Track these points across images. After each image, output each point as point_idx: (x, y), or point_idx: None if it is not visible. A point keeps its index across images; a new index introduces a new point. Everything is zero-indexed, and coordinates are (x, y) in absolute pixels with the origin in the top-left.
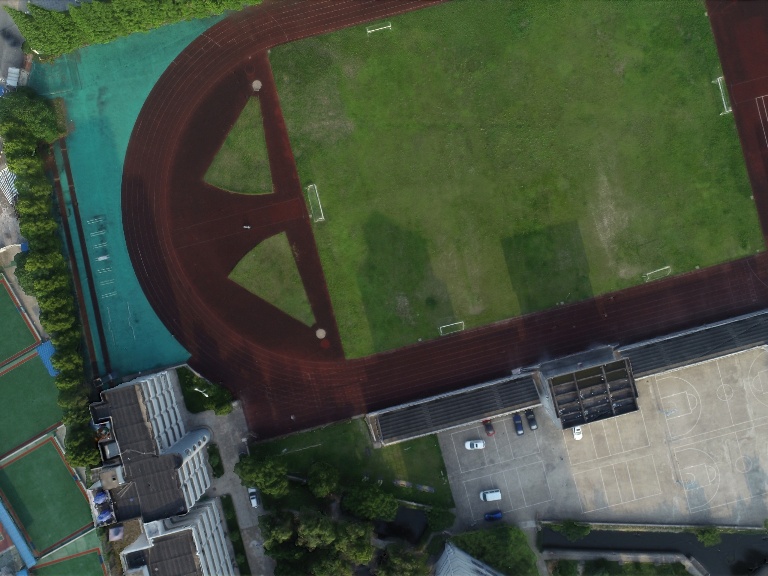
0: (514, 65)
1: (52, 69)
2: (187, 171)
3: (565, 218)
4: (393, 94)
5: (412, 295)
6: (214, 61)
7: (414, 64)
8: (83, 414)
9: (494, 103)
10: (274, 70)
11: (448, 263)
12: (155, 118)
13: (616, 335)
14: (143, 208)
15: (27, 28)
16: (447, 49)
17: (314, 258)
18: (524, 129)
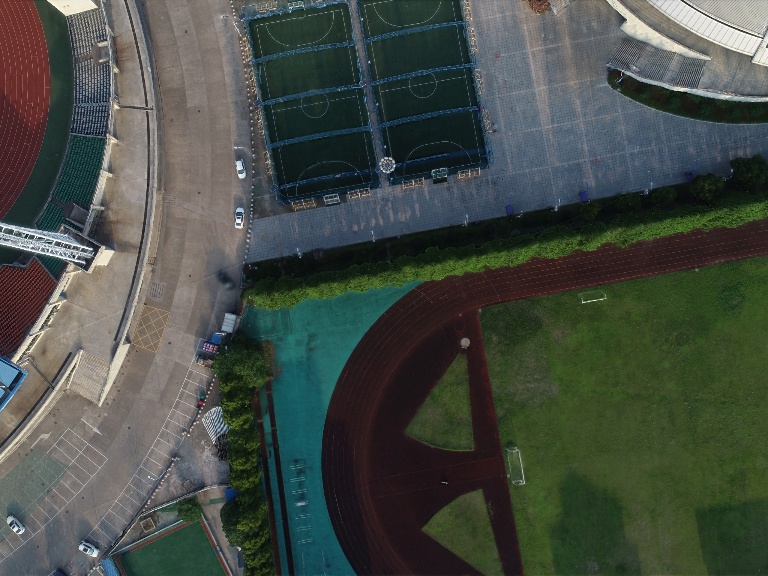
0: (723, 342)
1: (264, 313)
2: (389, 422)
3: (761, 497)
4: (600, 362)
5: (603, 561)
6: (425, 316)
7: (623, 334)
8: None
9: (700, 378)
10: (484, 330)
11: (641, 532)
12: (362, 368)
13: None
14: (343, 455)
15: (265, 302)
16: (657, 321)
17: (509, 517)
18: (728, 406)
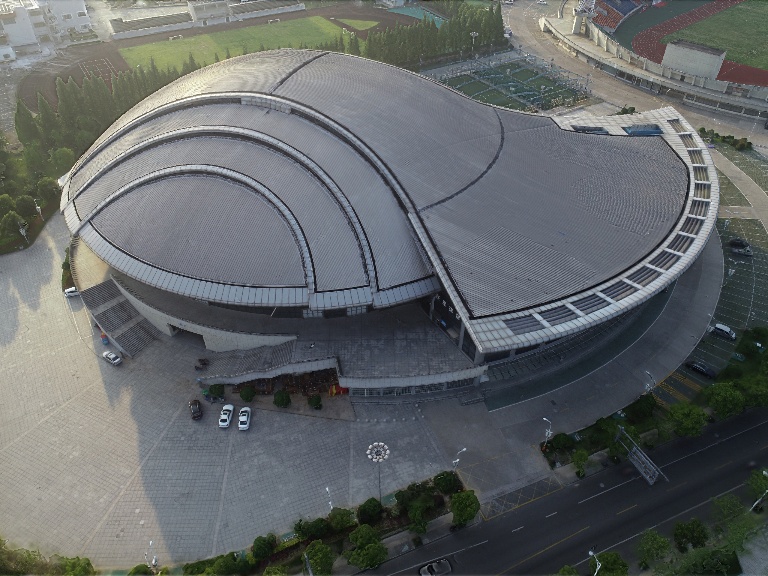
0: None
1: None
2: None
3: None
4: None
5: None
6: None
7: None
8: None
9: None
10: None
11: None
12: None
13: (194, 29)
14: None
15: None
16: None
17: None
18: None
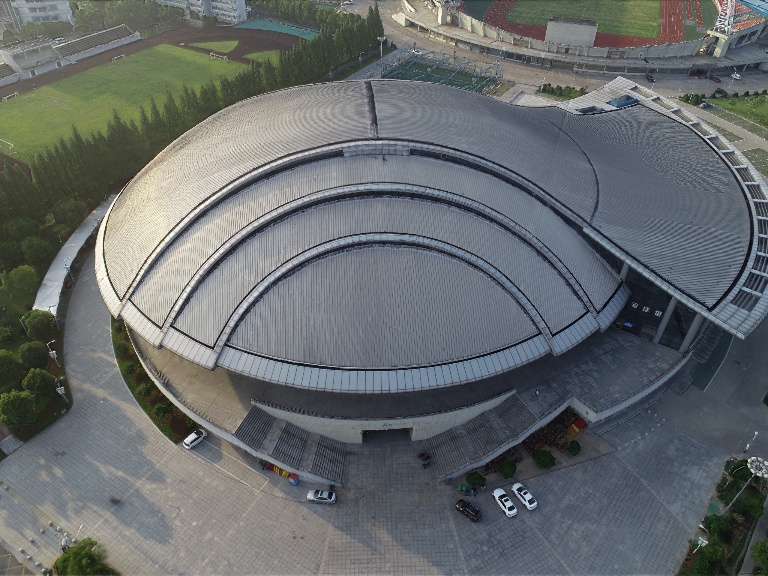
0: None
1: None
2: None
3: None
4: None
5: (148, 60)
6: None
7: None
8: (254, 1)
9: None
10: None
11: None
12: None
13: None
14: None
15: None
16: None
17: None
18: None
